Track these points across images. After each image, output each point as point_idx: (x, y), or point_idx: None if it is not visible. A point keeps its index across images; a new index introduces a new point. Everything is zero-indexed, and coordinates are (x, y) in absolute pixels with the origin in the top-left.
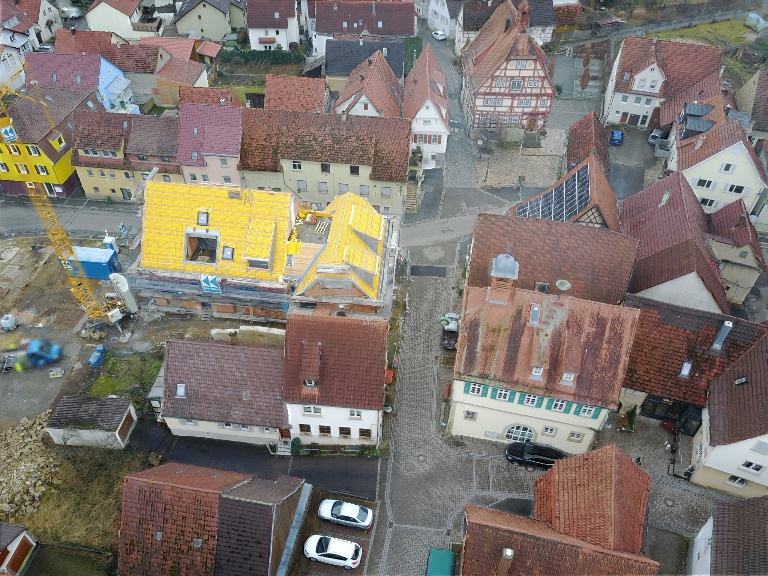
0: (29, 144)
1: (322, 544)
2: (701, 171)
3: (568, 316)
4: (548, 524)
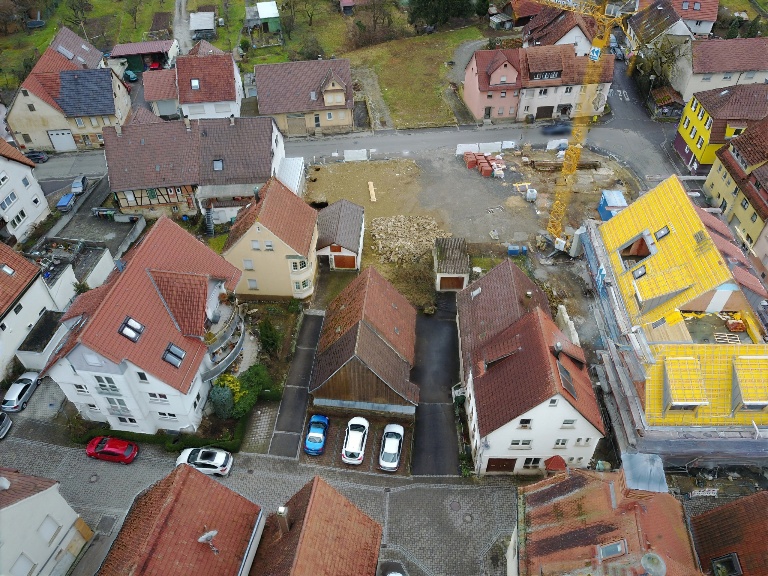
0: (710, 116)
1: (358, 427)
2: None
3: None
4: None
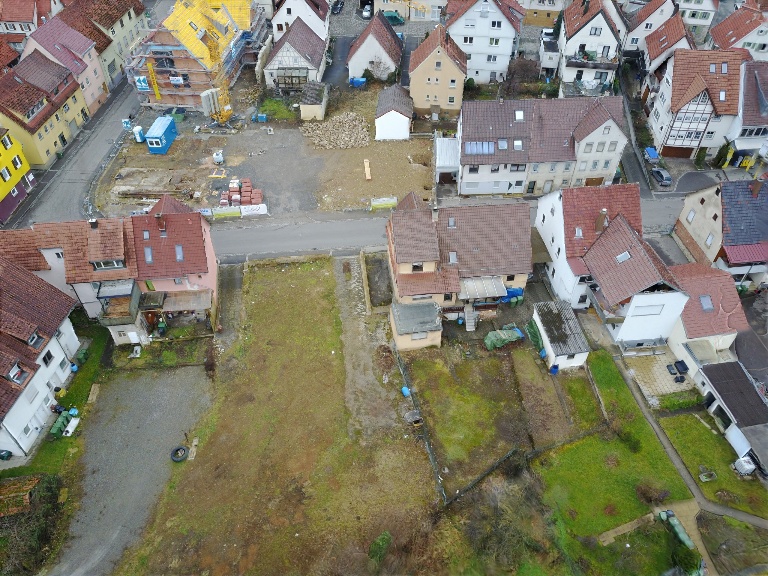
0: (4, 134)
1: None
2: None
3: None
4: None
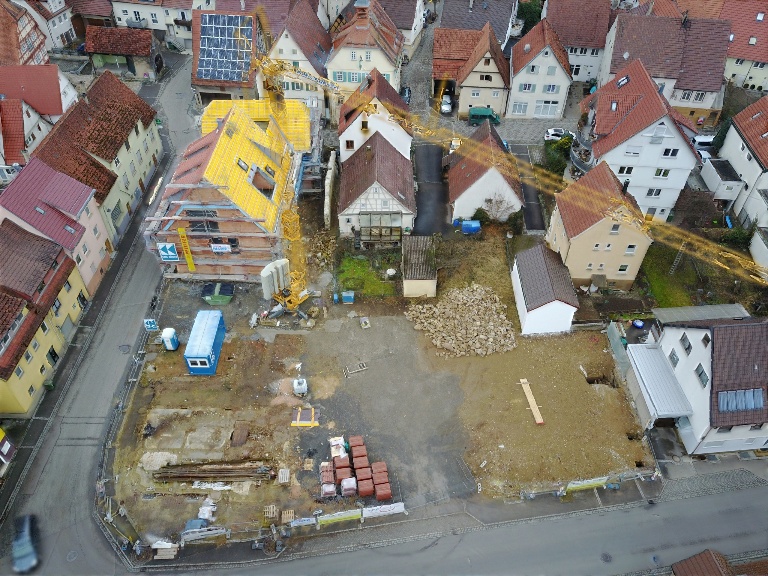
0: None
1: None
2: (195, 2)
3: (374, 13)
4: (460, 69)
